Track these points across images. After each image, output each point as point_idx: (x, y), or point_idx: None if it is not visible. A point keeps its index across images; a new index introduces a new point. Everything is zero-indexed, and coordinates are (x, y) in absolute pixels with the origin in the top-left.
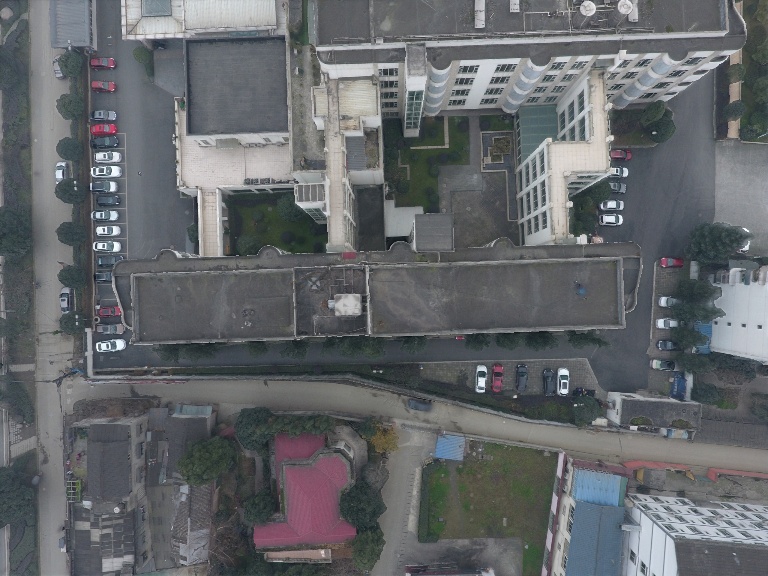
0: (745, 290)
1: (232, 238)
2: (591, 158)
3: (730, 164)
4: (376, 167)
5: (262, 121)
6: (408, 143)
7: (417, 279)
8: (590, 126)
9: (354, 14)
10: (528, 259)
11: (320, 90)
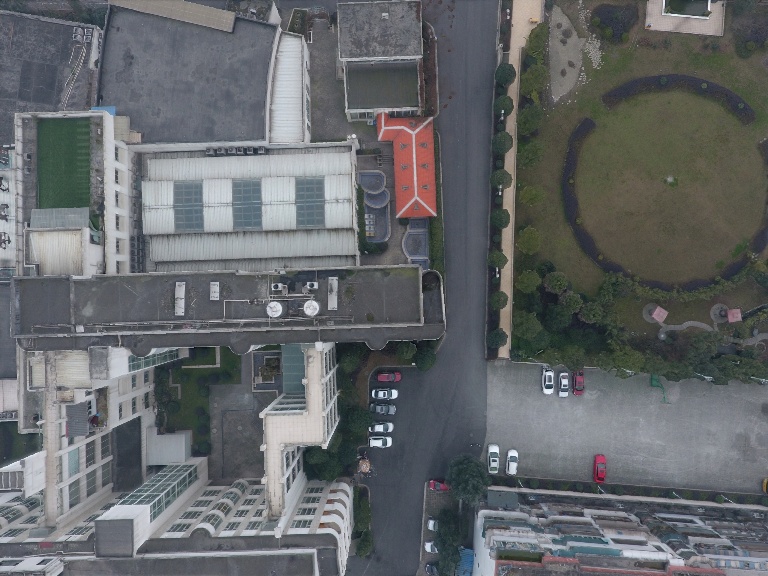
0: (484, 541)
1: (1, 459)
2: (308, 429)
3: (502, 383)
4: (104, 427)
5: (7, 364)
6: (177, 364)
7: (115, 568)
8: (307, 398)
9: (57, 299)
10: (224, 551)
11: (37, 360)
